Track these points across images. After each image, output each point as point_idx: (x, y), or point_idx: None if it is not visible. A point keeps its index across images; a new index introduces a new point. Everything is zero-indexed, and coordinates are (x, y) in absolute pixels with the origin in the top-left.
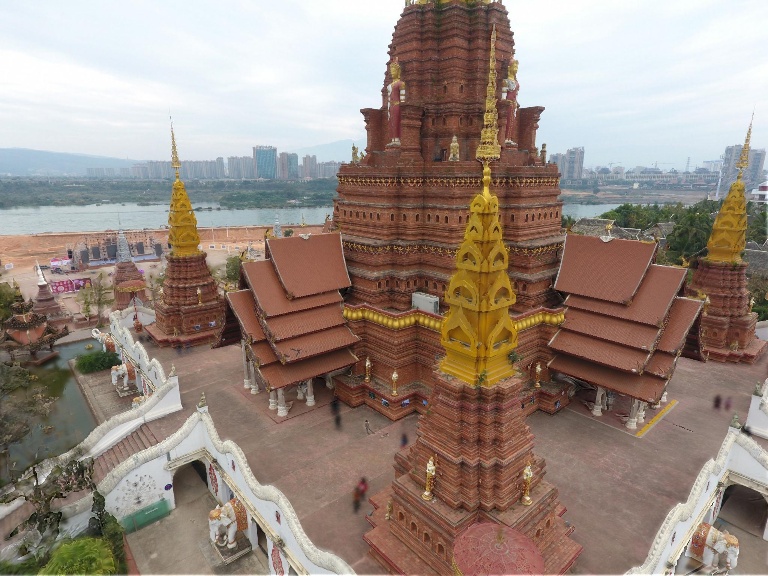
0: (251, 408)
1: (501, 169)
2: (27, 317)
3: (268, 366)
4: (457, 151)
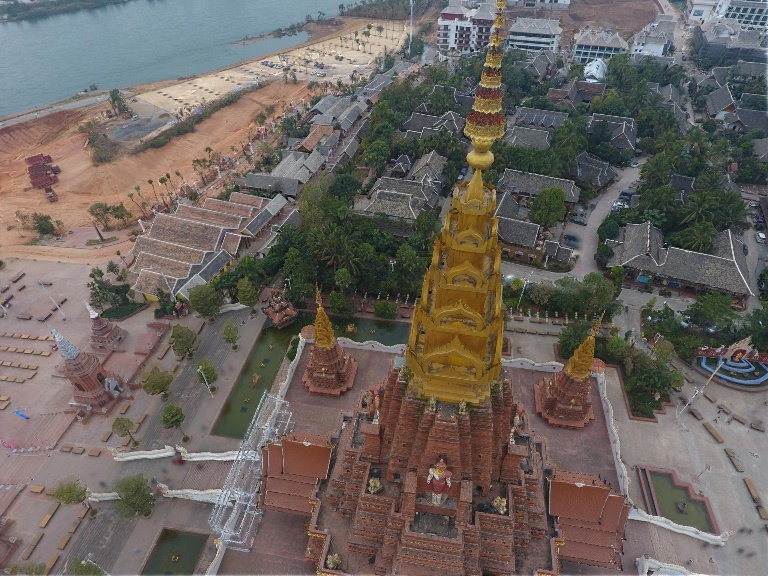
0: None
1: None
2: None
3: None
4: None
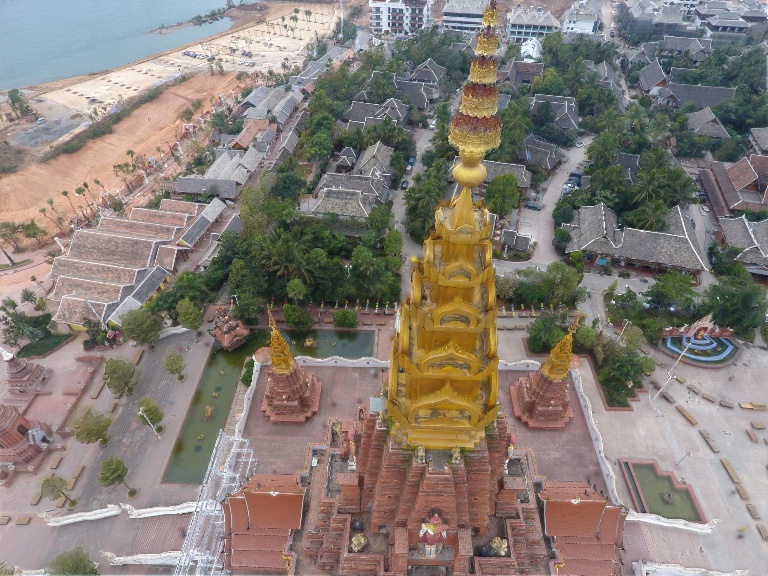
0: None
1: None
2: None
3: None
4: None
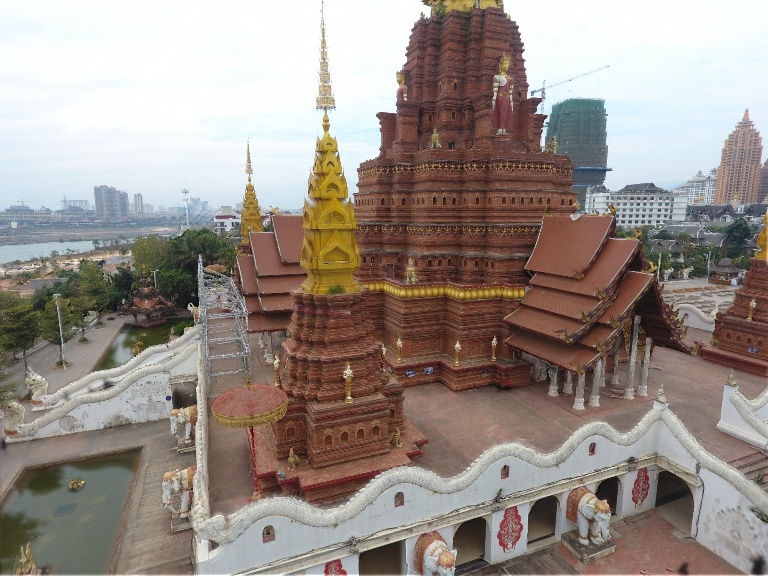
0: (634, 408)
1: None
2: None
3: None
4: None
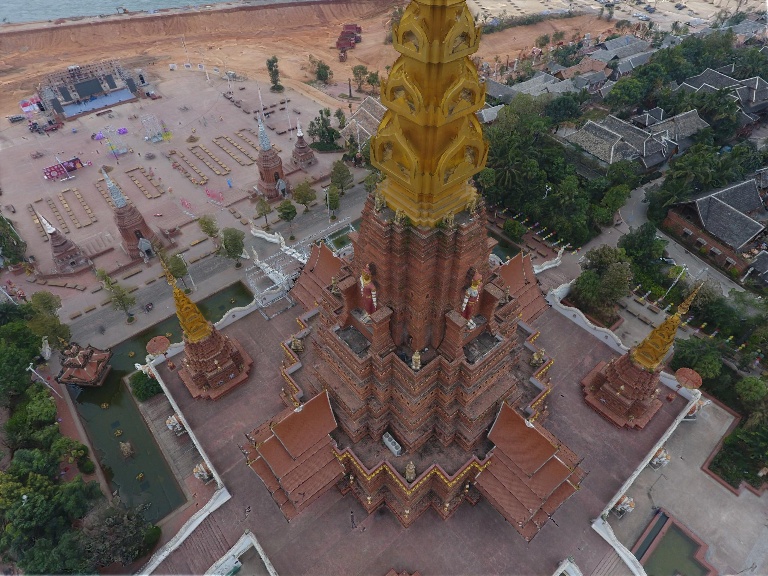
0: None
1: (455, 367)
2: (80, 358)
3: (285, 503)
4: (418, 361)
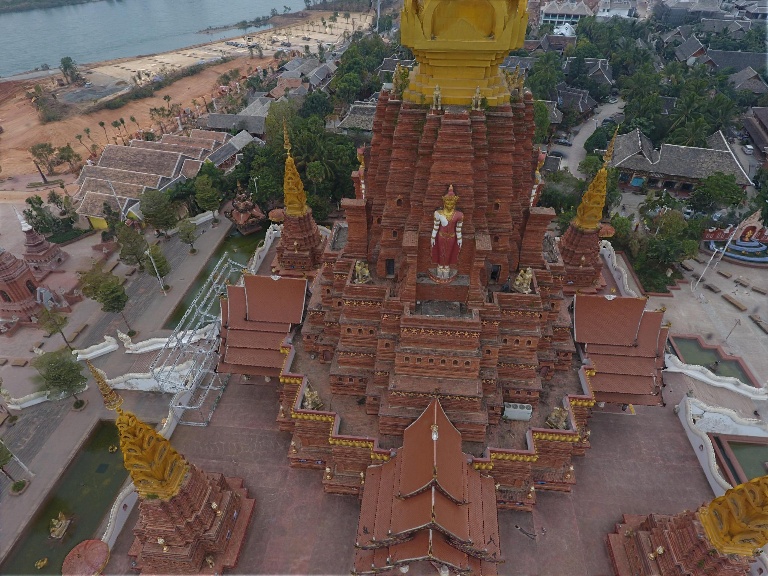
0: None
1: None
2: None
3: None
4: None
